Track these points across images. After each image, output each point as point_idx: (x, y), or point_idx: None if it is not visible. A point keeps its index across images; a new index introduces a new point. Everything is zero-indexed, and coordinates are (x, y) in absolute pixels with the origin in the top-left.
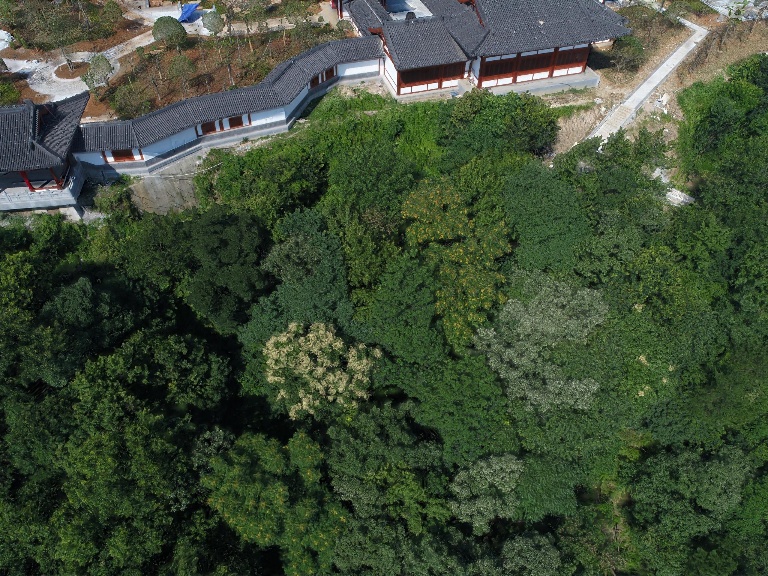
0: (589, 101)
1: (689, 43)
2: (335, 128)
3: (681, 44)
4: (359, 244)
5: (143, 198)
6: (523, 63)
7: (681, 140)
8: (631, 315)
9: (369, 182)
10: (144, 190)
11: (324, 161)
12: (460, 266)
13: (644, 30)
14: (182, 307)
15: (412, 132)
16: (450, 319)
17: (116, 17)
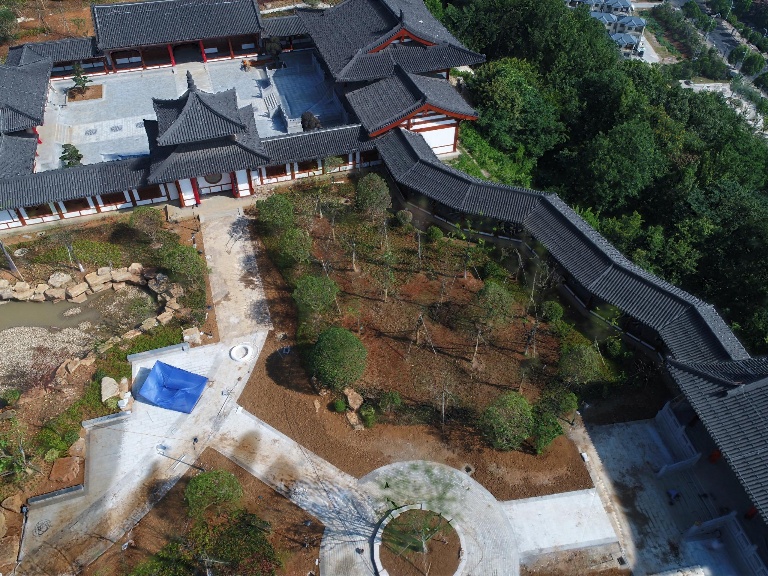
0: None
1: None
2: None
3: None
4: None
5: None
6: None
7: None
8: (674, 91)
9: None
10: None
11: None
12: None
13: None
14: None
15: None
16: None
17: None
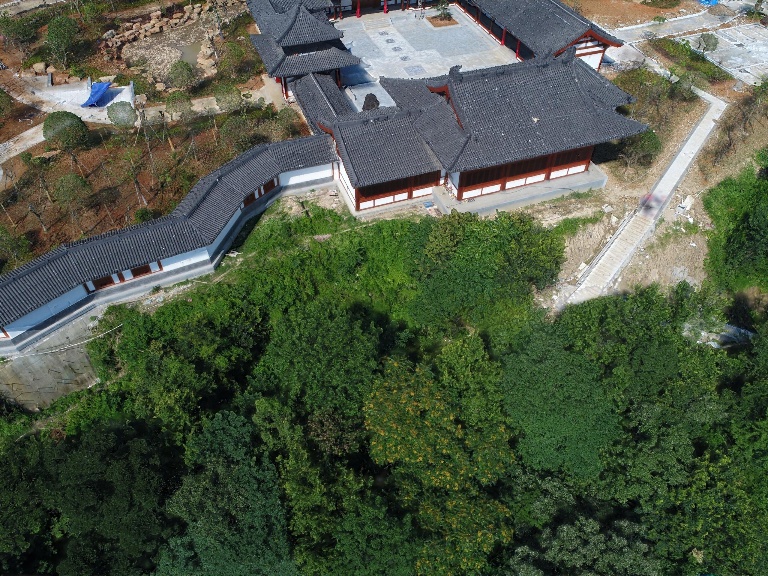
0: (596, 209)
1: (706, 121)
2: (275, 266)
3: (697, 123)
4: (302, 486)
5: (13, 384)
6: (513, 167)
7: (712, 257)
8: (689, 568)
9: (317, 370)
10: (13, 374)
11: (262, 312)
12: (447, 493)
13: (651, 104)
14: (67, 541)
15: (376, 260)
16: (436, 573)
17: (1, 107)
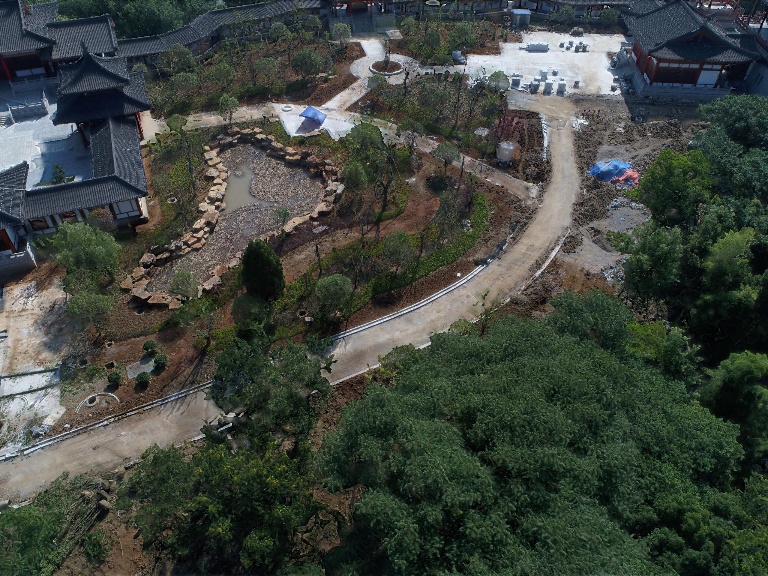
0: None
1: None
2: None
3: None
4: None
5: None
6: None
7: None
8: None
9: None
10: None
11: None
12: None
13: None
14: None
15: None
16: None
17: None
